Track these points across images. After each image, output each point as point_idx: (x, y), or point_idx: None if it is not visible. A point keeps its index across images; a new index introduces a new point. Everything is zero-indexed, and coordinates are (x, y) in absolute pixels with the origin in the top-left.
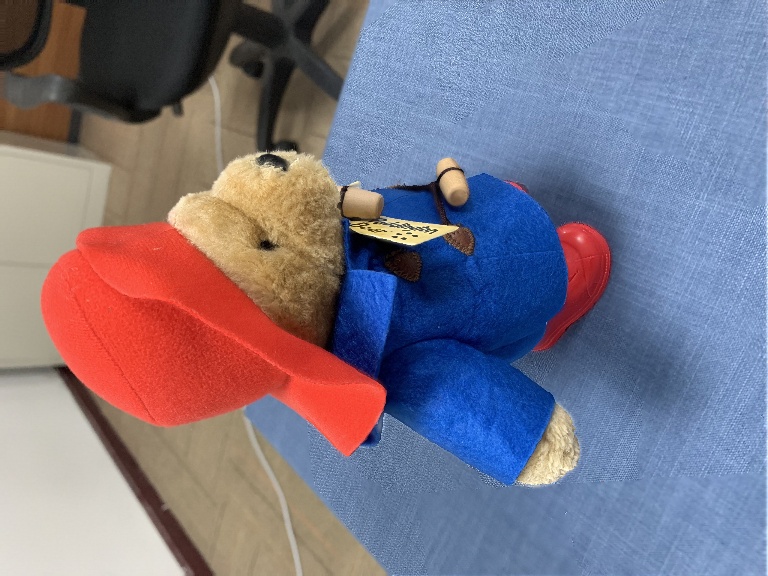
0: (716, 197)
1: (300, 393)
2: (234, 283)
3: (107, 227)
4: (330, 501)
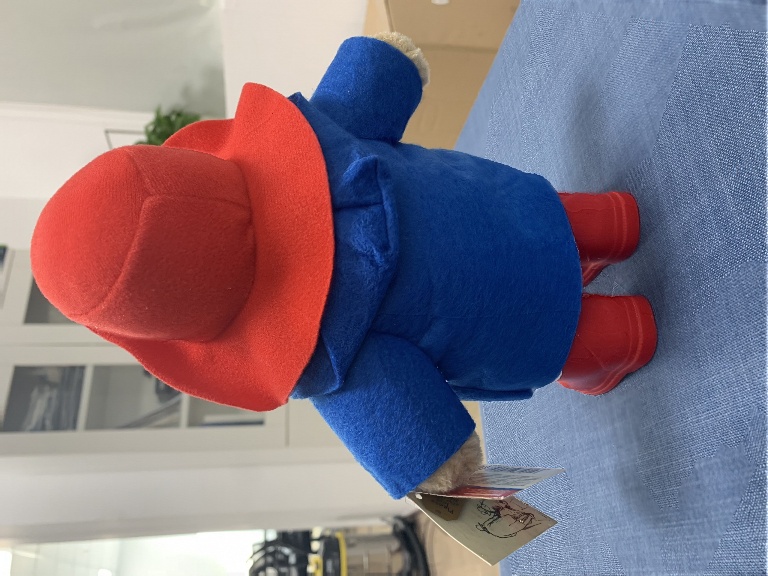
0: None
1: (232, 145)
2: None
3: None
4: None
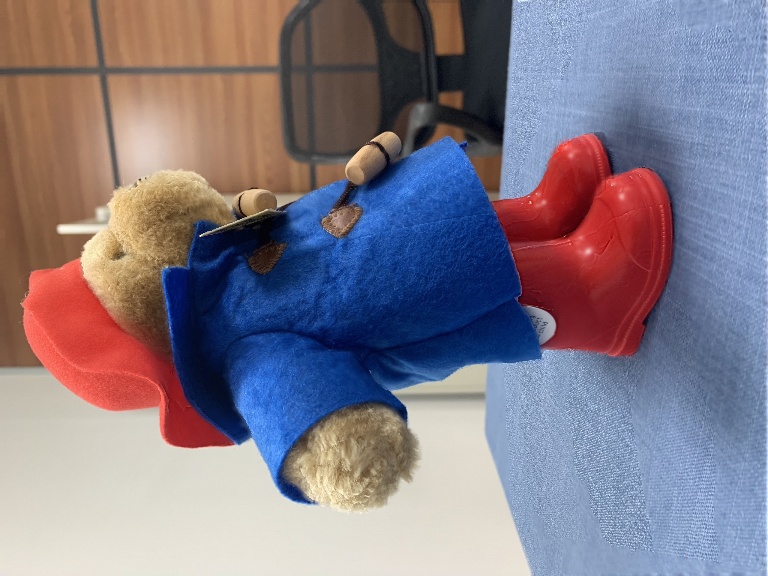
0: (764, 70)
1: None
2: (90, 290)
3: None
4: (519, 535)
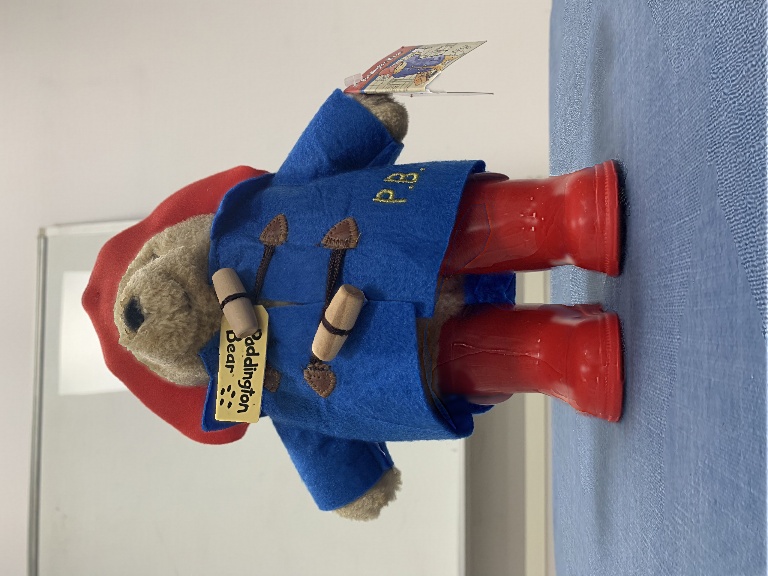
0: None
1: None
2: None
3: (108, 253)
4: None
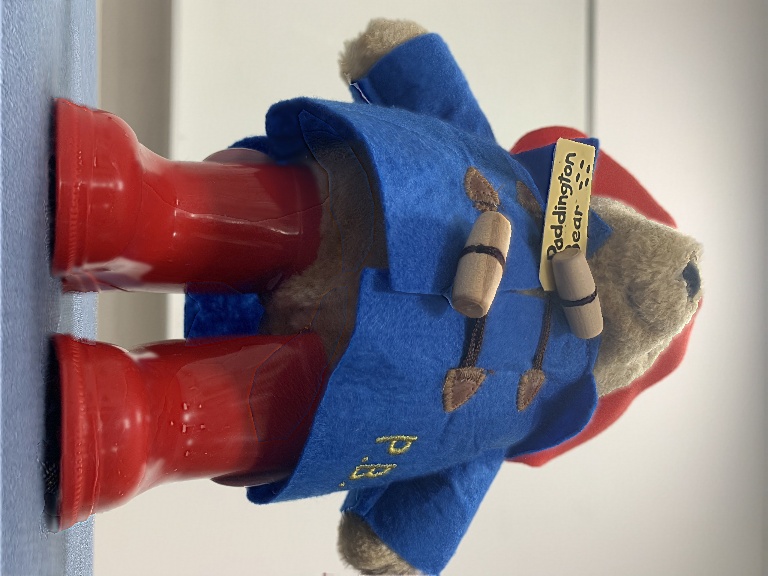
0: None
1: None
2: None
3: None
4: None
